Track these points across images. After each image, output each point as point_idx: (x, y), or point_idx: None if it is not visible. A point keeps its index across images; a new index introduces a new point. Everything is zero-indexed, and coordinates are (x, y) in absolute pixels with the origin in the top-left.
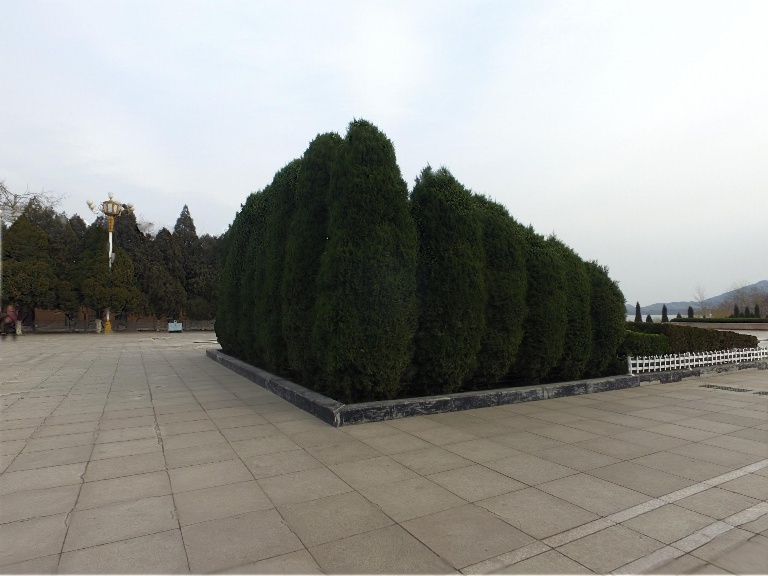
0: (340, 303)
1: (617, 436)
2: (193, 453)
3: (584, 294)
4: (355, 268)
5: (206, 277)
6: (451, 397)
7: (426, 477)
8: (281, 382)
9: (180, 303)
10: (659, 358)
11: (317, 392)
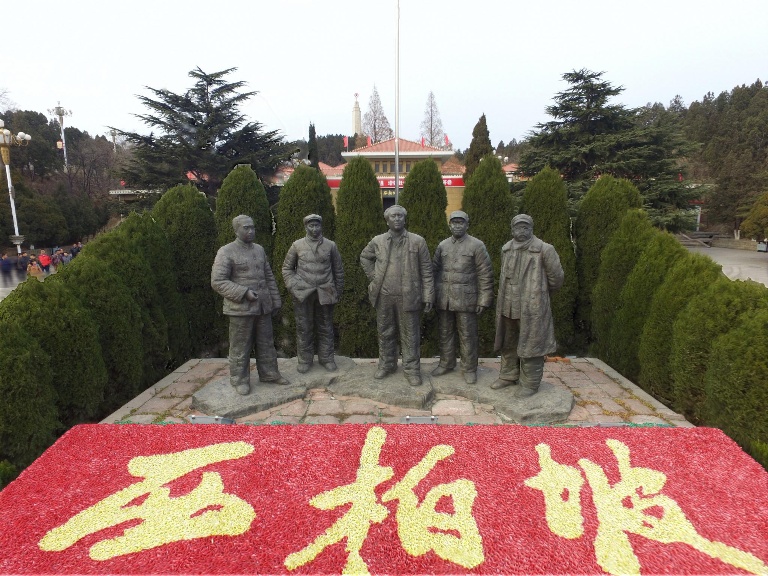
0: None
1: None
2: None
3: None
4: None
5: None
6: None
7: None
8: None
9: None
10: None
11: None
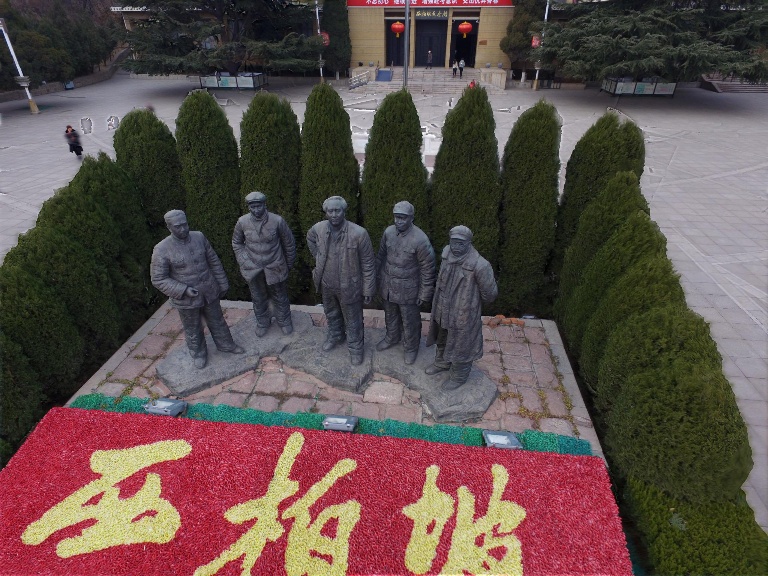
0: None
1: None
2: None
3: None
4: None
5: None
6: None
7: None
8: None
9: None
10: None
11: None
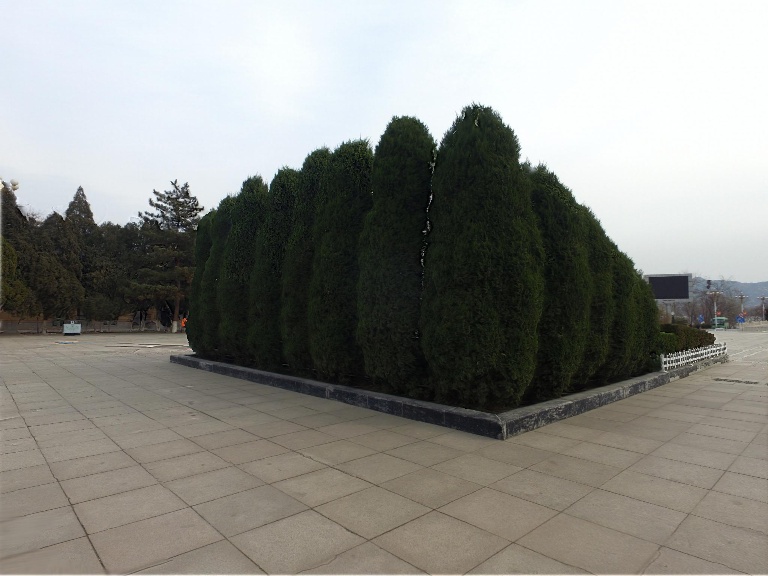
0: (478, 303)
1: (767, 432)
2: (419, 485)
3: (639, 296)
4: (494, 265)
5: (109, 271)
6: (573, 401)
7: (717, 491)
8: (359, 391)
9: (76, 301)
10: (677, 355)
11: (428, 401)
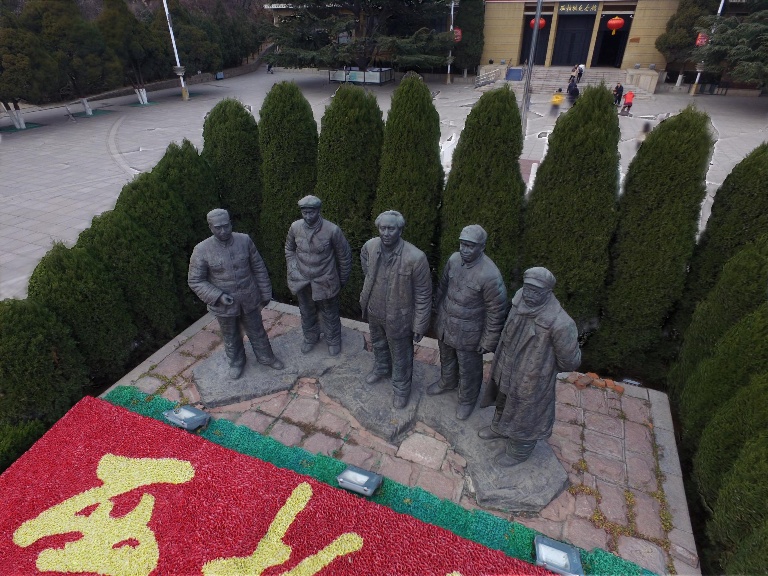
0: None
1: None
2: None
3: None
4: None
5: None
6: None
7: None
8: None
9: None
10: None
11: None
